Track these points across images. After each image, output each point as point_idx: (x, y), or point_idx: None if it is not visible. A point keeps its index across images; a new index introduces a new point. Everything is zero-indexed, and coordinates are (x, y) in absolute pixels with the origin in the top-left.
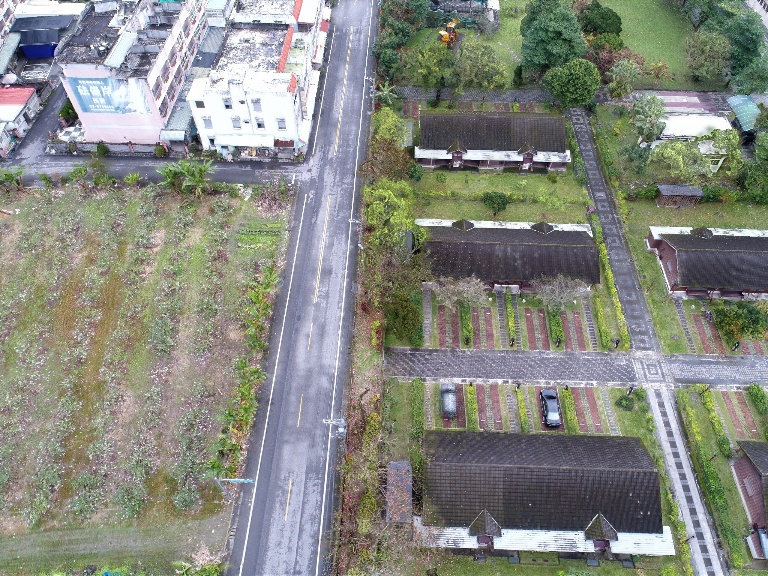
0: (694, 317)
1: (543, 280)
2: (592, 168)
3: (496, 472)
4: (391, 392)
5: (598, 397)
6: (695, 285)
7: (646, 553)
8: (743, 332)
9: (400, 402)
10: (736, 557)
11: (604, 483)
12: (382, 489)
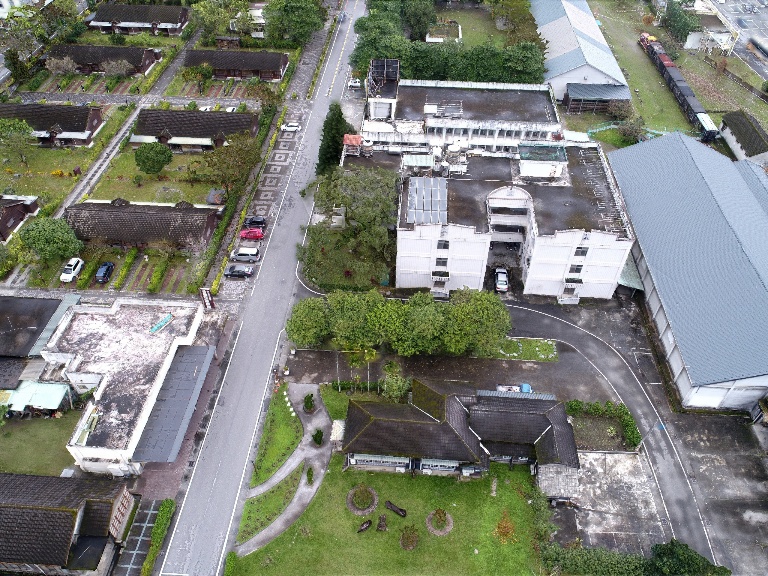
0: (193, 85)
1: (110, 63)
2: (198, 36)
3: (13, 107)
4: None
5: (111, 107)
6: (191, 66)
7: (72, 138)
8: None
9: None
10: None
11: (63, 112)
12: None
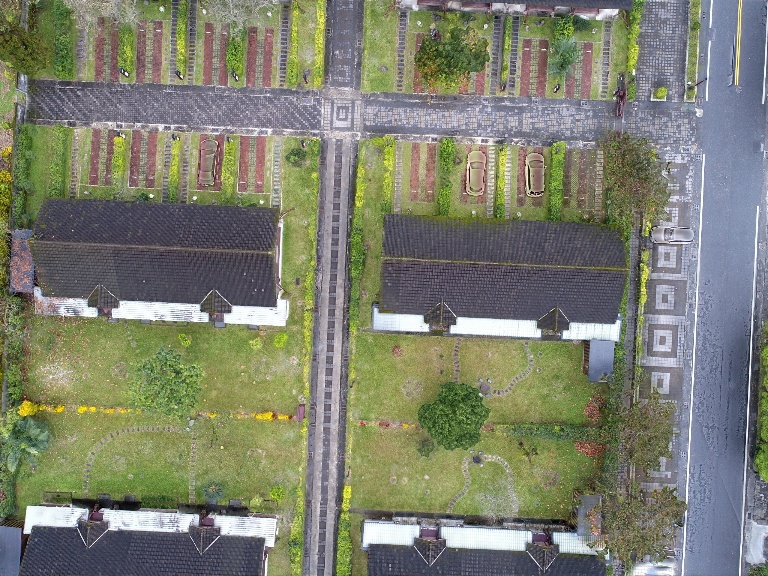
0: (417, 38)
1: None
2: None
3: (105, 251)
4: (34, 140)
5: (269, 149)
6: None
7: (257, 324)
8: (439, 76)
9: (43, 153)
10: (351, 325)
11: (217, 263)
12: (9, 257)
